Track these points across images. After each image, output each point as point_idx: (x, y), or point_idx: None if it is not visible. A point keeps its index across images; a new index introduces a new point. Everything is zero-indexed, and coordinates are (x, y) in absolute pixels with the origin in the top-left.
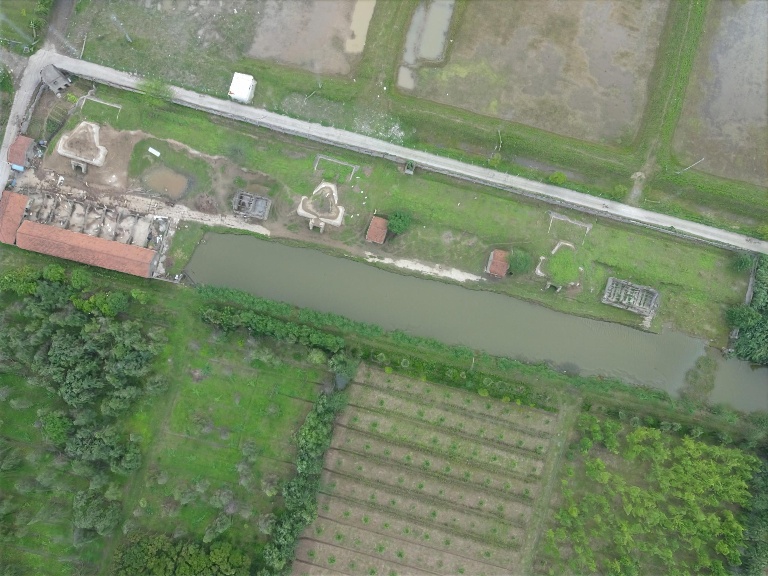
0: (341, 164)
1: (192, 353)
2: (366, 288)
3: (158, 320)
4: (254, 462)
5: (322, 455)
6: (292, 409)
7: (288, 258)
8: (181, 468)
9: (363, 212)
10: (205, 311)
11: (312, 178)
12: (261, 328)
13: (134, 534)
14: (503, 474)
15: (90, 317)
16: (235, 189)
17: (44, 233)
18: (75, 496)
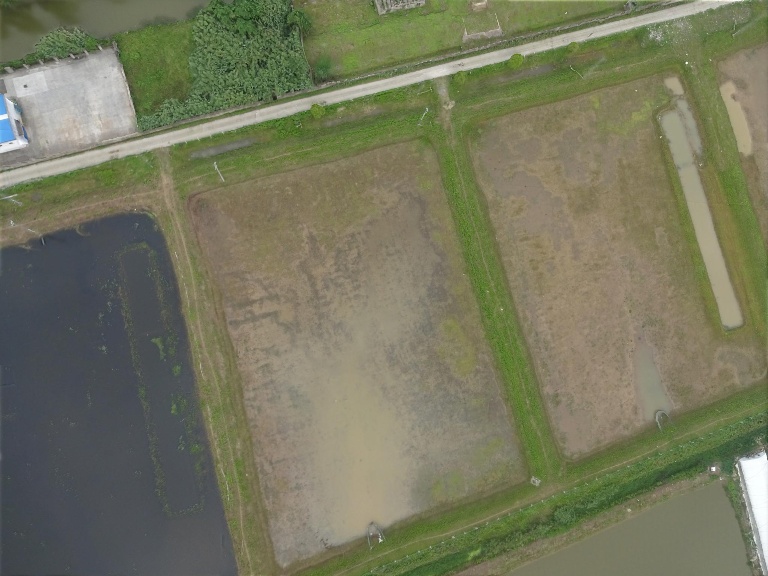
0: None
1: None
2: None
3: None
4: None
5: None
6: None
7: None
8: None
9: None
10: None
11: None
12: None
13: None
14: None
15: None
16: None
17: None
18: None
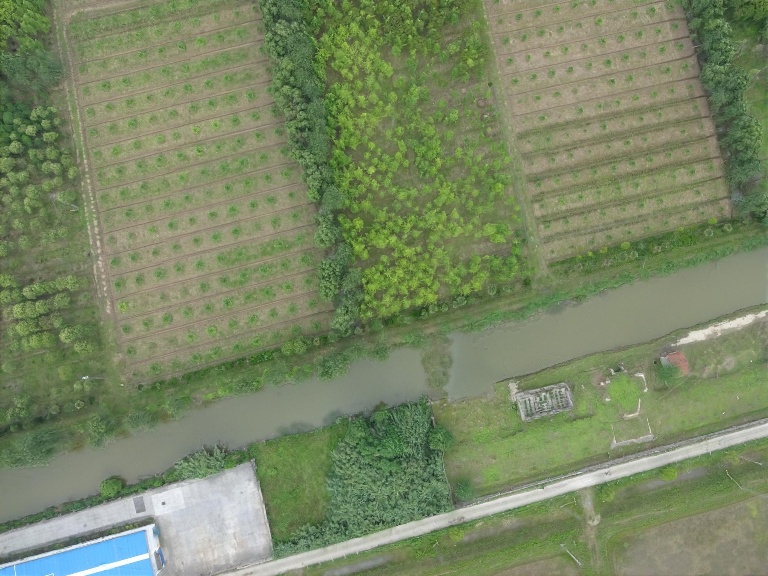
0: None
1: None
2: (767, 280)
3: None
4: None
5: (727, 124)
6: (763, 149)
7: None
8: None
9: None
10: None
11: None
12: None
13: None
14: (565, 189)
15: None
16: None
17: None
18: None
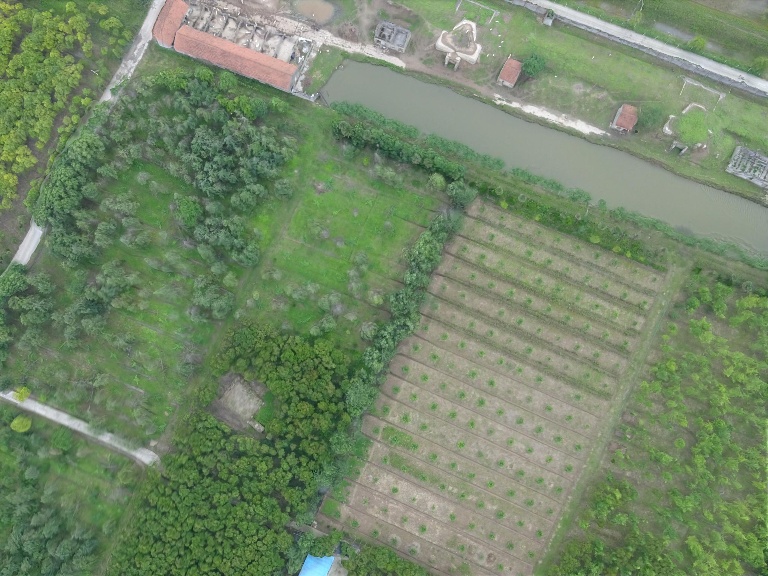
0: (482, 7)
1: (318, 167)
2: (491, 127)
3: (291, 131)
4: (363, 274)
5: (430, 274)
6: (405, 231)
7: (418, 93)
8: (294, 271)
9: (498, 54)
10: (338, 124)
11: (453, 17)
12: (390, 144)
13: (246, 318)
14: (603, 323)
15: (232, 116)
16: (378, 21)
17: (200, 37)
18: (196, 278)
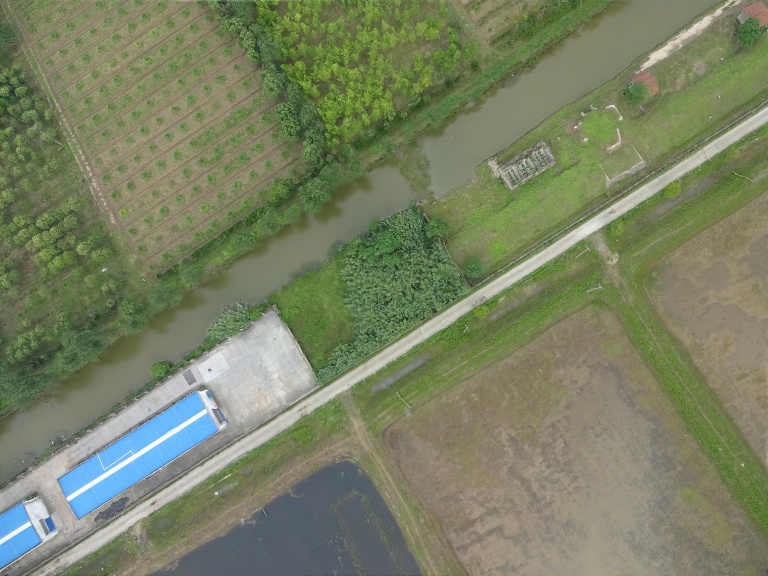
0: None
1: None
2: None
3: None
4: None
5: None
6: None
7: None
8: None
9: None
10: None
11: None
12: None
13: None
14: None
15: None
16: None
17: None
18: None
